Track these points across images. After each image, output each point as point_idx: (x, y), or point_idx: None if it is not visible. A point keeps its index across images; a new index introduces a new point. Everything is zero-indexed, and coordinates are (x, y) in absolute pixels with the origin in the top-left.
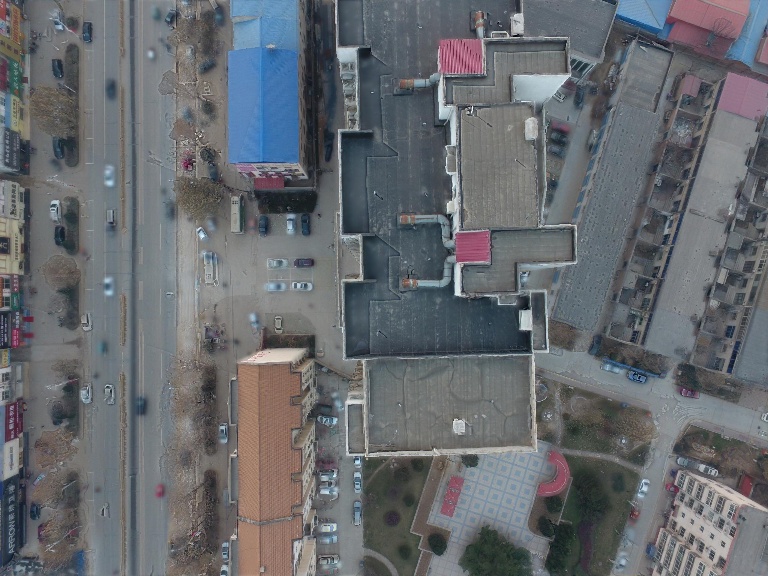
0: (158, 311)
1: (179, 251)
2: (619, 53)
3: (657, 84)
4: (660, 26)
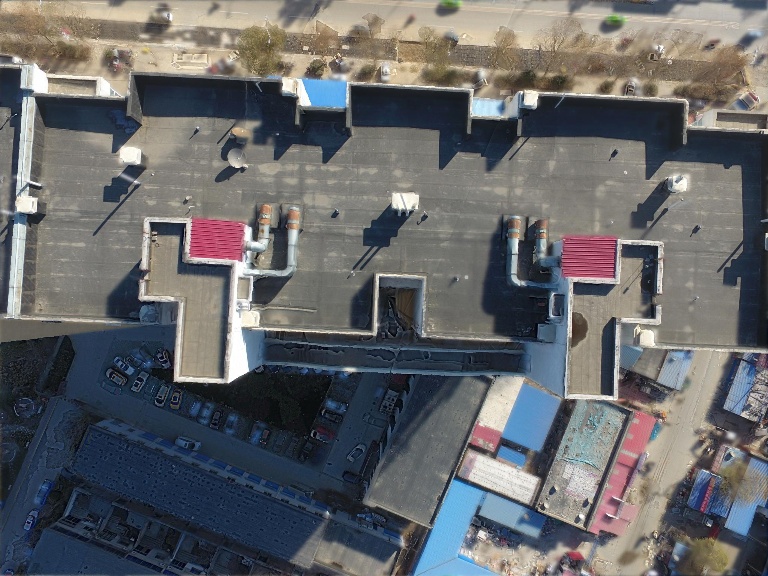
0: (155, 4)
1: (218, 31)
2: (398, 527)
3: (353, 567)
4: (417, 575)
